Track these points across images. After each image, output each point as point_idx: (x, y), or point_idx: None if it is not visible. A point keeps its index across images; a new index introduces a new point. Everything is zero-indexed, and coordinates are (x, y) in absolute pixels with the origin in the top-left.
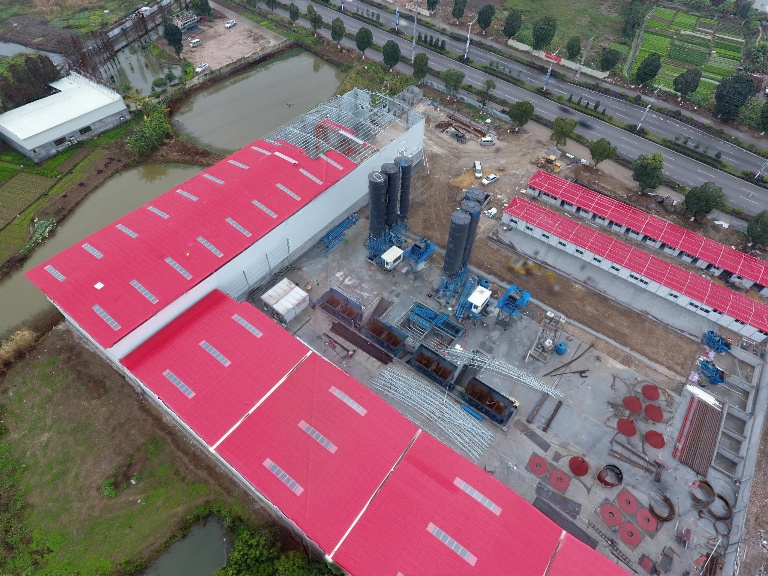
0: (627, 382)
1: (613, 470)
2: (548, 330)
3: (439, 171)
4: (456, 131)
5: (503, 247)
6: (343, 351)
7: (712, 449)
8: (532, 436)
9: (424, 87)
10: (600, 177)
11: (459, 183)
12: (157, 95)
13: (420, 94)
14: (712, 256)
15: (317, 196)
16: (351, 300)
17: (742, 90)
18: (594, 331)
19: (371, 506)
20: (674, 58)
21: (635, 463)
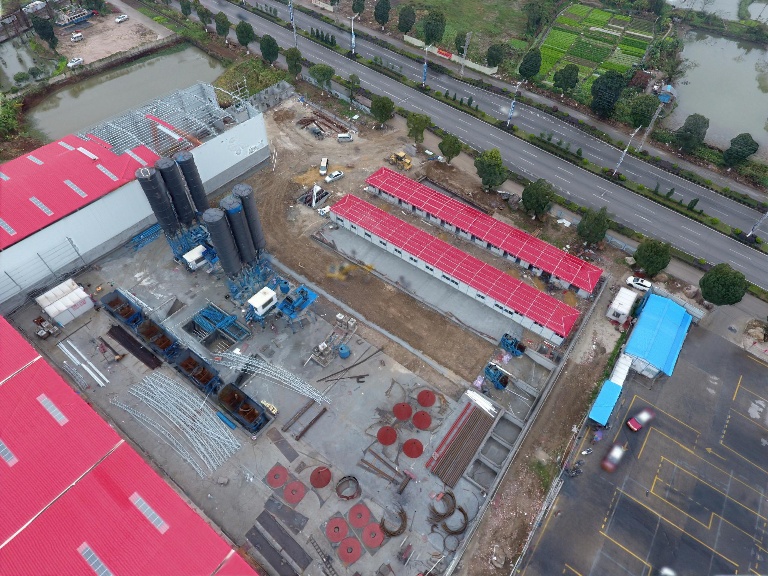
0: (405, 387)
1: (356, 481)
2: (339, 333)
3: (285, 168)
4: (317, 127)
5: (324, 246)
6: (112, 355)
7: (470, 458)
8: (282, 445)
9: (301, 83)
10: (453, 174)
11: (301, 180)
12: (13, 90)
13: (290, 90)
14: (532, 255)
15: (108, 193)
16: (131, 302)
17: (612, 86)
18: (390, 334)
19: (33, 524)
20: (575, 54)
21: (382, 474)
